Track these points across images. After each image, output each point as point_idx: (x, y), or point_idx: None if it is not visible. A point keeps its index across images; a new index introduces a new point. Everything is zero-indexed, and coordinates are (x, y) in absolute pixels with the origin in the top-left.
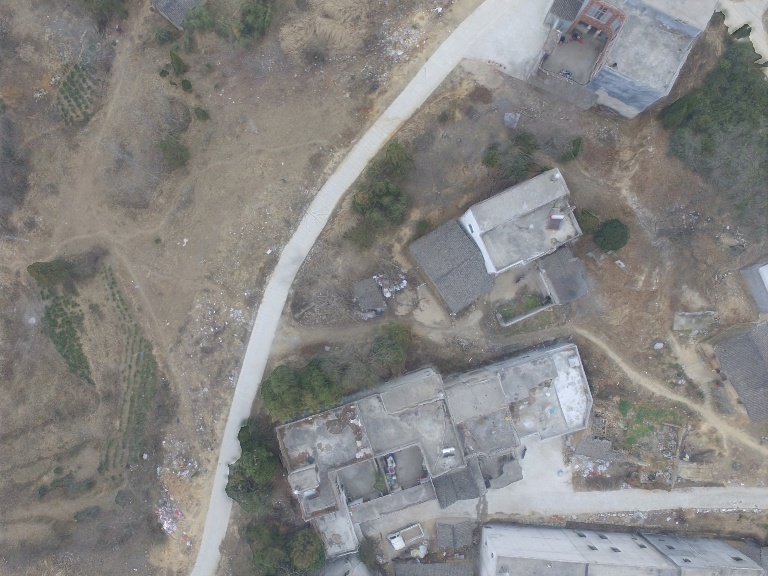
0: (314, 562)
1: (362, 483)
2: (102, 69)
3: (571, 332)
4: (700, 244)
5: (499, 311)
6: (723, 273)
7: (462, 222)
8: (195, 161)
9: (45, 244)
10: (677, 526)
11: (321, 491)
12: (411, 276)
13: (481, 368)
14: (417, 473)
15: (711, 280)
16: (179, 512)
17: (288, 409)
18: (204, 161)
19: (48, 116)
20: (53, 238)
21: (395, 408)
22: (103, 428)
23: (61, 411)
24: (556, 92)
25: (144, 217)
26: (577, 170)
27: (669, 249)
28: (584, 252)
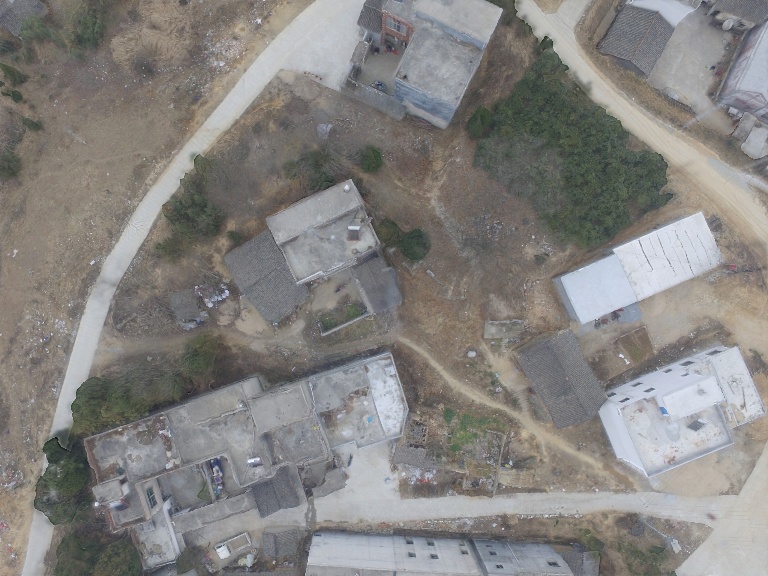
0: (121, 573)
1: (191, 492)
2: None
3: (394, 341)
4: (504, 253)
5: (321, 320)
6: (531, 282)
7: None
8: (27, 172)
9: None
10: (503, 532)
11: (131, 502)
12: (233, 286)
13: (306, 377)
14: None
15: (519, 289)
16: (4, 524)
17: (87, 421)
18: (36, 172)
19: None
20: None
21: (198, 419)
22: None
23: None
24: (368, 103)
25: None
26: (389, 180)
27: (475, 258)
28: (400, 261)
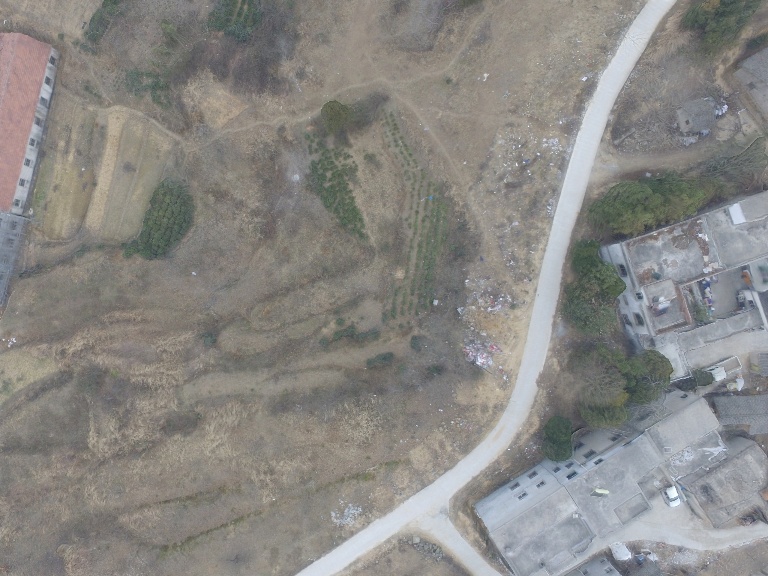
0: None
1: None
2: None
3: None
4: None
5: None
6: None
7: None
8: None
9: (317, 94)
10: None
11: (668, 308)
12: (732, 101)
13: None
14: (730, 306)
15: None
16: (494, 346)
17: (653, 214)
18: None
19: None
20: (325, 88)
21: (754, 216)
22: (379, 281)
23: (329, 268)
24: None
25: (429, 60)
26: None
27: None
28: None
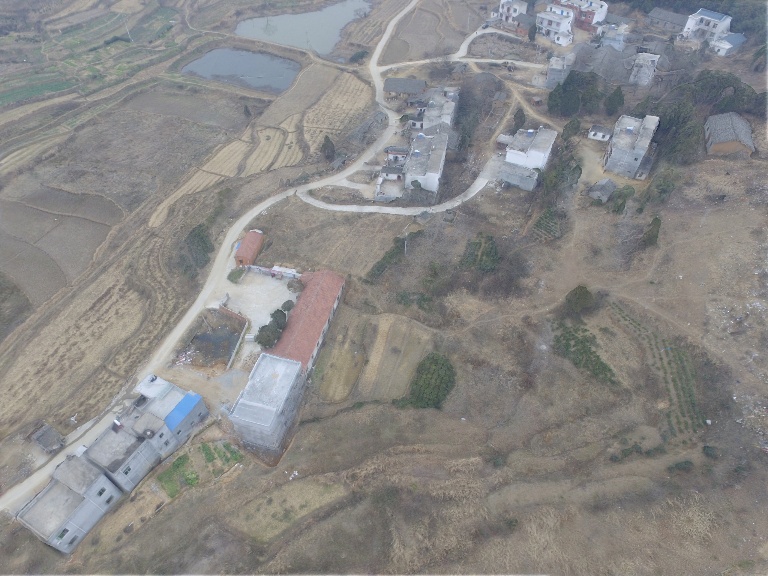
0: None
1: None
2: (560, 217)
3: None
4: None
5: None
6: None
7: None
8: (661, 243)
9: (552, 295)
10: None
11: None
12: None
13: None
14: None
15: None
16: None
17: None
18: (667, 243)
19: (525, 240)
20: (556, 292)
21: None
22: (644, 413)
23: (590, 408)
24: None
25: (630, 274)
26: None
27: None
28: None
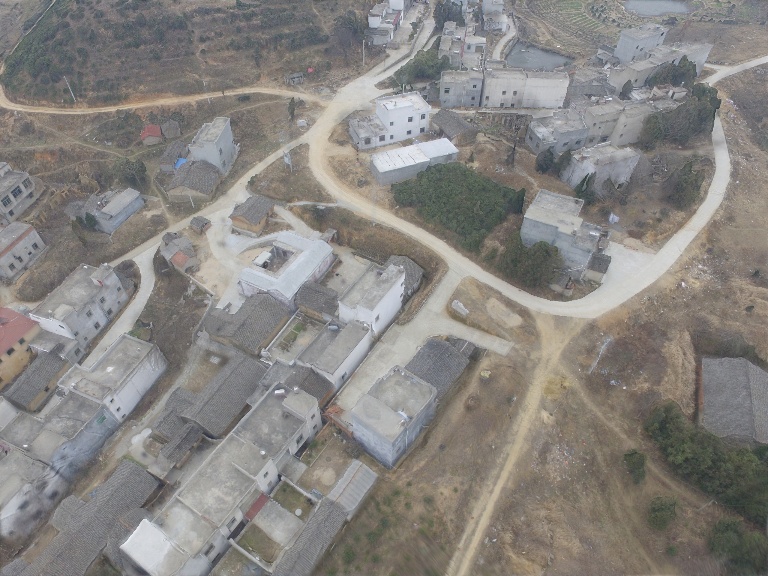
0: None
1: None
2: None
3: None
4: None
5: None
6: None
7: None
8: None
9: None
10: None
11: None
12: None
13: (585, 146)
14: None
15: None
16: None
17: None
18: None
19: None
20: None
21: (644, 107)
22: None
23: None
24: None
25: None
26: None
27: None
28: None
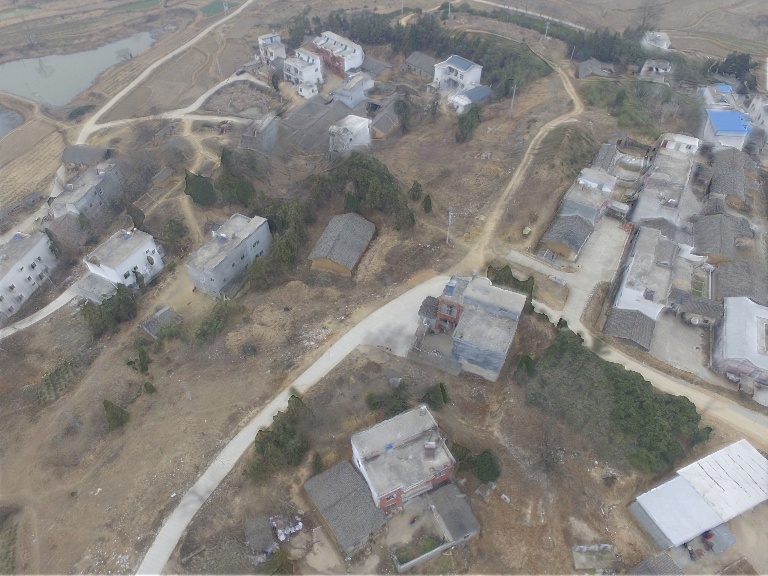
0: None
1: None
2: (85, 364)
3: None
4: (573, 476)
5: None
6: (608, 507)
7: (354, 461)
8: (133, 423)
9: None
10: None
11: None
12: (307, 518)
13: None
14: None
15: (598, 513)
16: None
17: None
18: (140, 423)
19: (27, 398)
20: None
21: None
22: None
23: None
24: (430, 363)
25: (71, 473)
26: (453, 418)
27: (546, 481)
28: (472, 490)
